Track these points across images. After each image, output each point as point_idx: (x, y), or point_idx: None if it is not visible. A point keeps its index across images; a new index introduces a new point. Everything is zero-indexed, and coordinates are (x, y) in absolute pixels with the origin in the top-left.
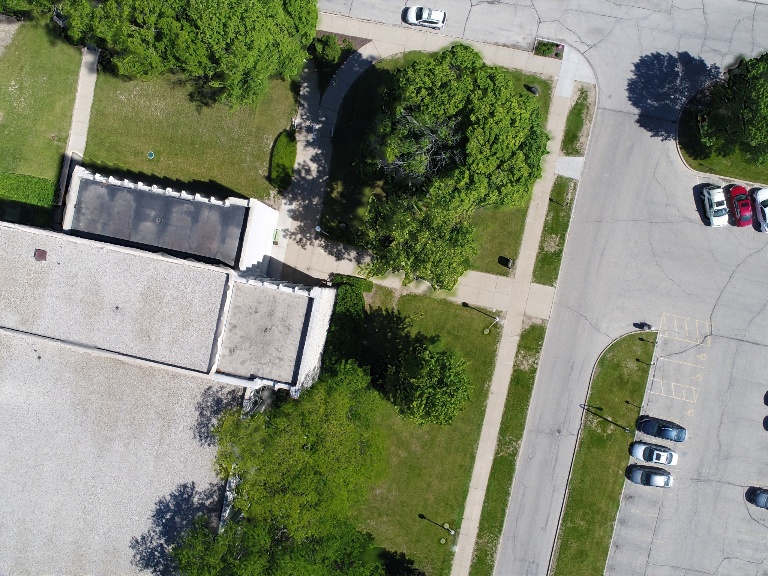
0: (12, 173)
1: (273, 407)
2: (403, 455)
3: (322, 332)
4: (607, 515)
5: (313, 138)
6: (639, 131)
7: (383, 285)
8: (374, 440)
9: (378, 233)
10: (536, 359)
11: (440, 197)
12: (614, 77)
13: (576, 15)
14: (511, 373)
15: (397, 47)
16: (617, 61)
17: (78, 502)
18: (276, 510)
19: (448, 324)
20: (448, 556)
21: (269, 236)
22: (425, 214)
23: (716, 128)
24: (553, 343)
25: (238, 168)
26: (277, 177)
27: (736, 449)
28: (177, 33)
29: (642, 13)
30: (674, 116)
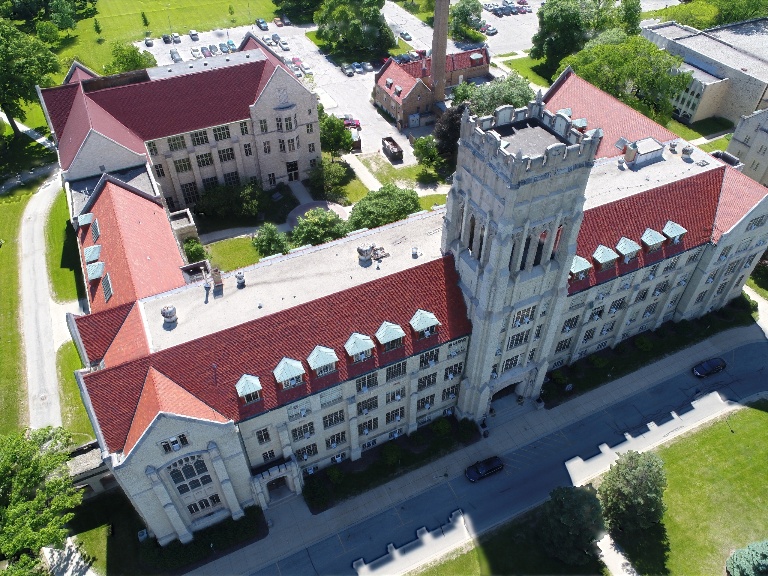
0: None
1: None
2: None
3: None
4: None
5: None
6: None
7: None
8: None
9: None
10: None
11: None
12: None
13: None
14: None
15: None
16: None
17: None
18: None
19: None
20: None
21: None
22: None
23: None
24: None
25: None
26: None
27: None
28: None
29: None
30: None
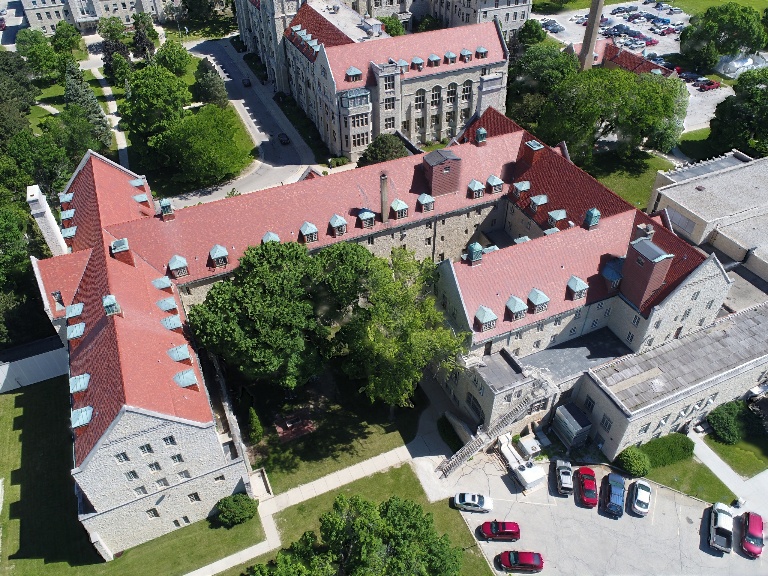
0: None
1: None
2: None
3: None
4: None
5: None
6: None
7: None
8: None
9: None
10: None
11: None
12: None
13: None
14: None
15: None
16: None
17: None
18: None
19: None
20: None
21: None
22: None
23: None
24: None
25: None
26: None
27: None
28: (672, 90)
29: None
30: None
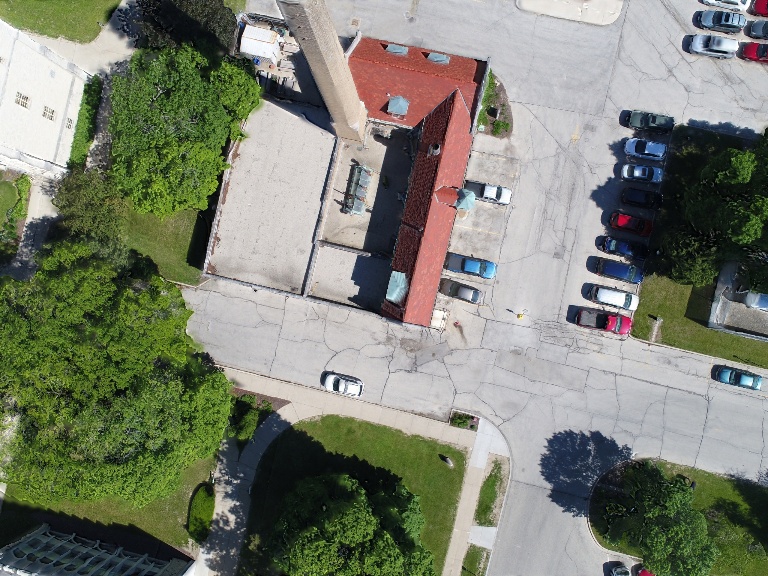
0: None
1: None
2: None
3: None
4: None
5: (232, 490)
6: (551, 506)
7: None
8: None
9: None
10: None
11: None
12: (528, 451)
13: (491, 388)
14: None
15: (315, 410)
16: (531, 436)
17: None
18: None
19: None
20: None
21: None
22: None
23: (620, 535)
24: None
25: (157, 515)
26: (194, 531)
27: None
28: None
29: (556, 390)
30: (586, 493)
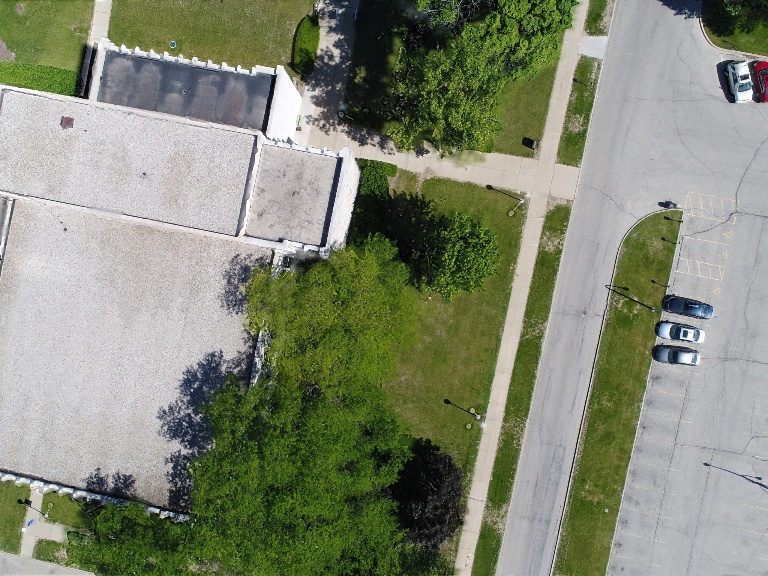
0: (34, 64)
1: (302, 270)
2: (428, 341)
3: (348, 208)
4: (634, 396)
5: (336, 24)
6: (662, 9)
7: (407, 170)
8: (404, 302)
9: (407, 88)
10: (561, 240)
11: (472, 41)
12: None
13: None
14: (536, 255)
15: None
16: None
17: (105, 374)
18: (307, 364)
19: (472, 207)
20: (474, 441)
21: (293, 119)
22: (458, 52)
23: None
24: (578, 224)
25: (261, 55)
26: (300, 62)
27: (763, 327)
28: None
29: None
30: None
